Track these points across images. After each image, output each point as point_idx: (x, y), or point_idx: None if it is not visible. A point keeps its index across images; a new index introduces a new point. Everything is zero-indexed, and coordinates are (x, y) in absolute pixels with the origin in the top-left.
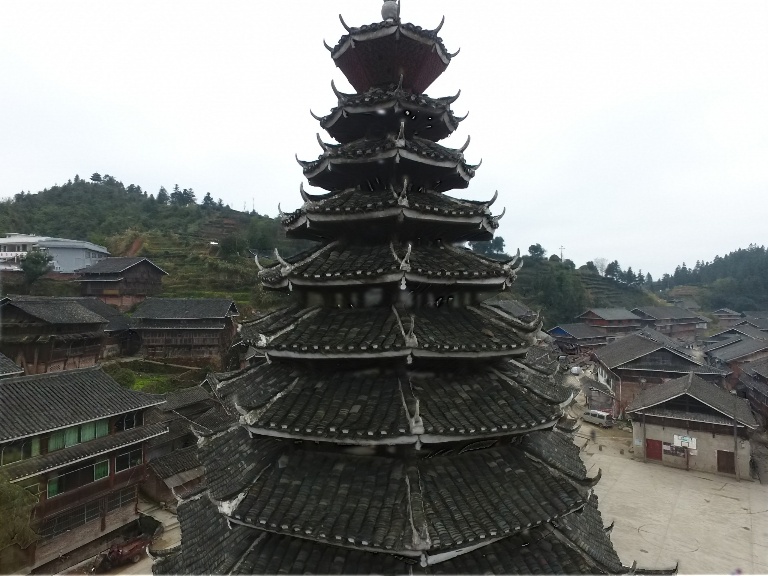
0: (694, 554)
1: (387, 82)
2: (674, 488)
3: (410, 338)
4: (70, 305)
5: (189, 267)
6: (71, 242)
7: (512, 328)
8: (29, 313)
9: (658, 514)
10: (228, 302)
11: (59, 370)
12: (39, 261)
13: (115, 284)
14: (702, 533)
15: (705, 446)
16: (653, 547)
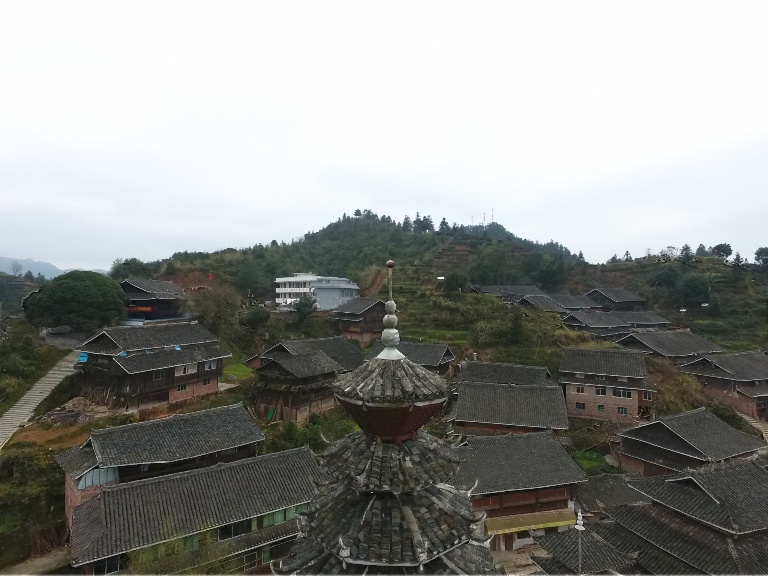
0: None
1: (372, 432)
2: None
3: None
4: (316, 355)
5: (417, 304)
6: (331, 283)
7: None
8: (285, 369)
9: None
10: (443, 348)
11: (306, 412)
12: (307, 304)
13: (357, 323)
14: None
15: None
16: None
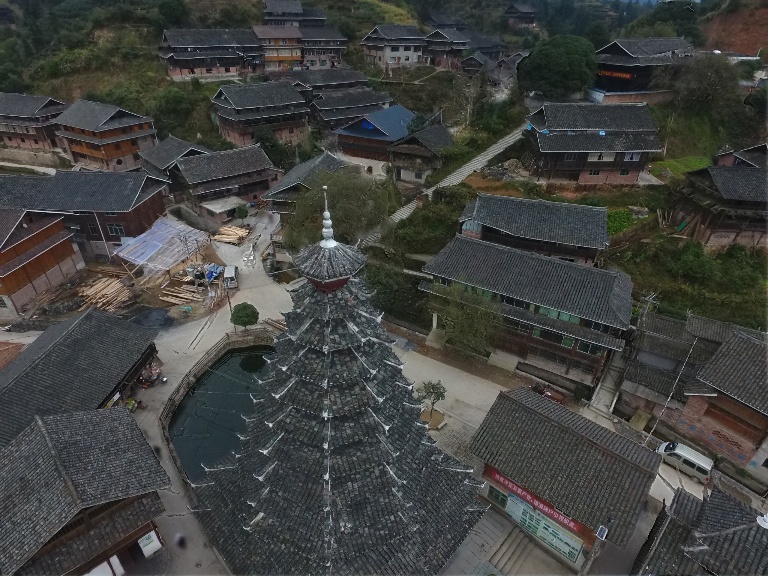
0: None
1: None
2: None
3: None
4: None
5: None
6: None
7: None
8: (714, 182)
9: None
10: None
11: (728, 239)
12: None
13: None
14: None
15: None
16: None
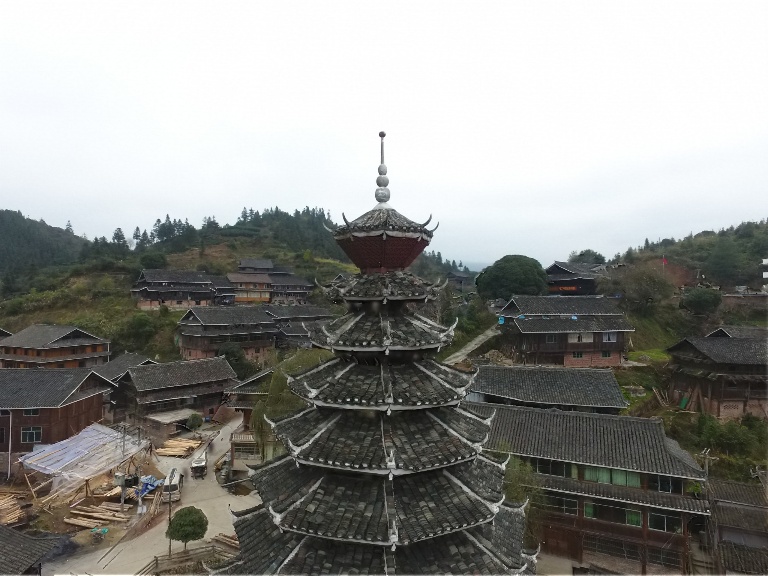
0: None
1: None
2: None
3: None
4: (764, 342)
5: None
6: None
7: None
8: (699, 350)
9: None
10: None
11: (737, 410)
12: None
13: None
14: None
15: None
16: None
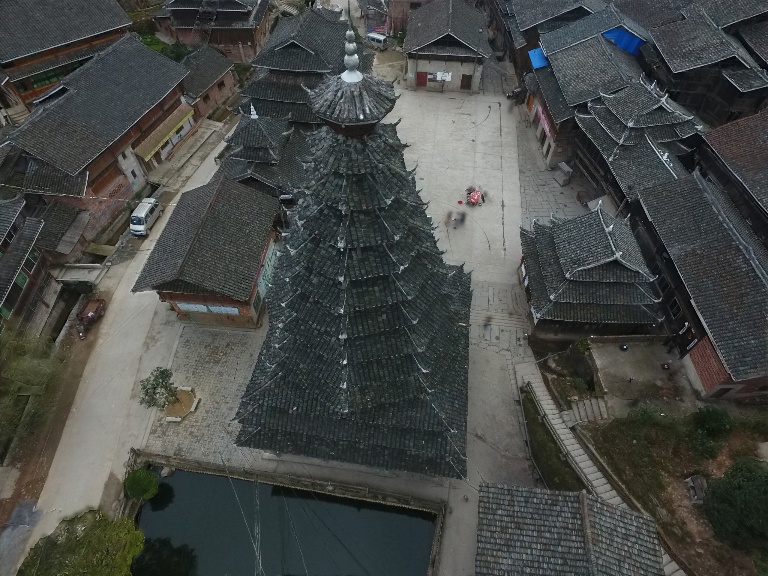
0: (447, 172)
1: None
2: (435, 115)
3: (410, 297)
4: None
5: None
6: None
7: (433, 253)
8: None
9: (427, 144)
10: None
11: None
12: None
13: None
14: (451, 153)
15: (455, 72)
16: (426, 174)
